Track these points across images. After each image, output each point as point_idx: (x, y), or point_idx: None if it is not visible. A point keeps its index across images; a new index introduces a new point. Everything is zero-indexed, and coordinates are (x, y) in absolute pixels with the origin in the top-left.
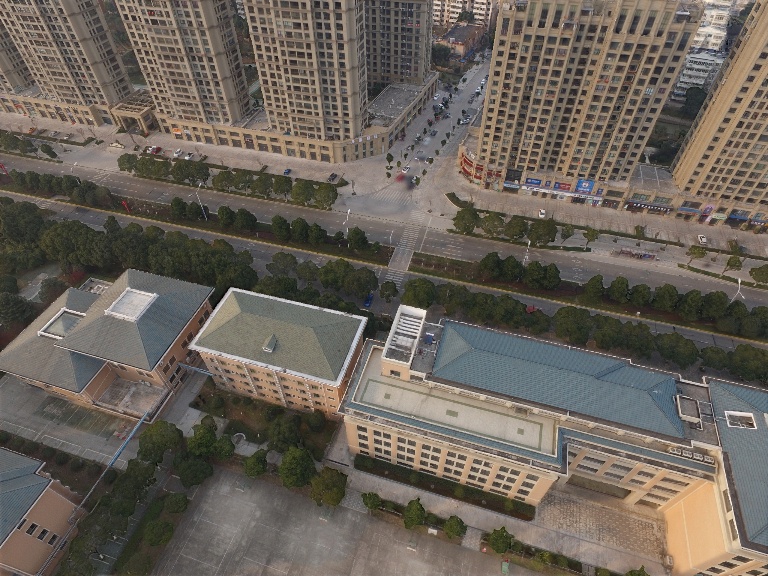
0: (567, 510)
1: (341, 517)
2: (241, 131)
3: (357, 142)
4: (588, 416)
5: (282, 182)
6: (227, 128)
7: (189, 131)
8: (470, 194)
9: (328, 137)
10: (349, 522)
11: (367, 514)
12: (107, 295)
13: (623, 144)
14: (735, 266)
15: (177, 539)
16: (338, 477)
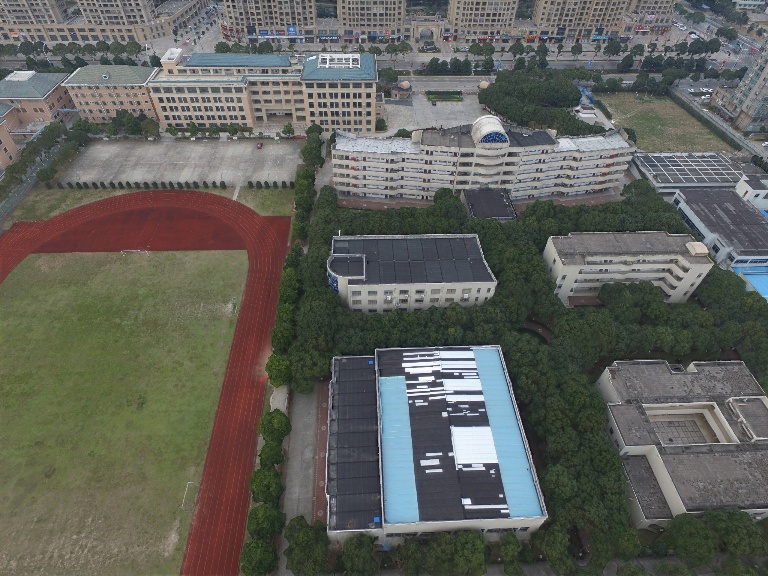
0: (268, 127)
1: (161, 144)
2: (65, 27)
3: (151, 25)
4: (253, 66)
5: (102, 43)
6: (54, 26)
7: (24, 33)
8: (226, 41)
9: (130, 23)
10: (165, 144)
11: (174, 141)
12: (2, 80)
13: (302, 0)
14: (362, 50)
15: (78, 160)
16: (153, 120)
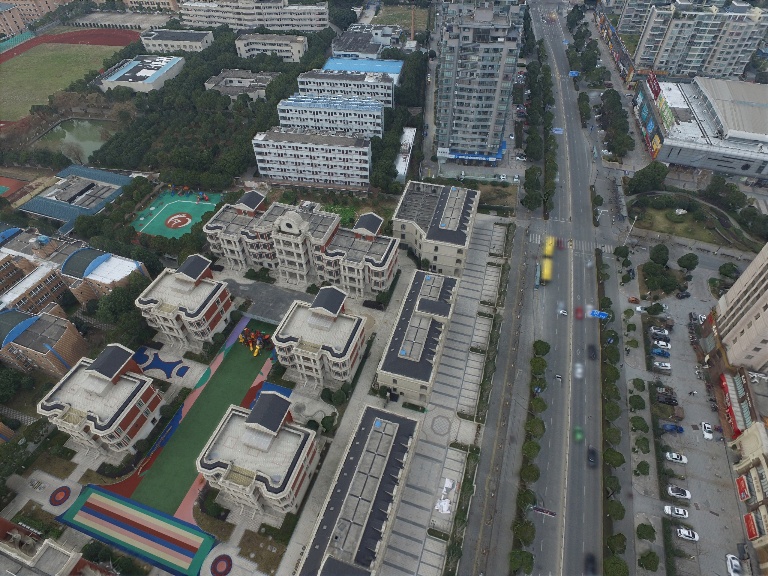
0: None
1: (125, 14)
2: None
3: None
4: None
5: None
6: None
7: None
8: None
9: None
10: None
11: None
12: None
13: None
14: None
15: None
16: (121, 1)
